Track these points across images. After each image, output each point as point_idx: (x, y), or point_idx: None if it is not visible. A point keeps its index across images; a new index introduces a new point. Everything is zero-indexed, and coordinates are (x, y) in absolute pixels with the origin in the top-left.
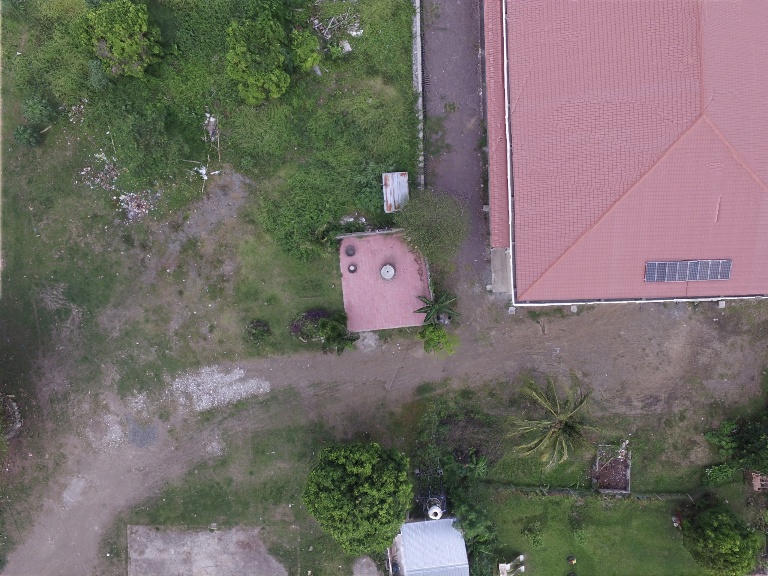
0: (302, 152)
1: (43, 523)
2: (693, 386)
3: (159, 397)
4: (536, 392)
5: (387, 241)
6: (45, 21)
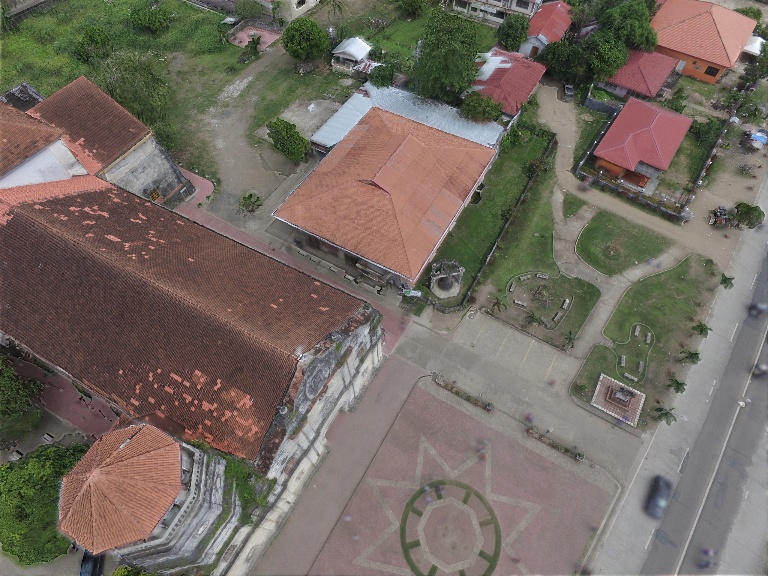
0: (189, 38)
1: (219, 159)
2: (367, 1)
3: (217, 105)
4: (331, 27)
5: (242, 33)
6: (56, 71)
